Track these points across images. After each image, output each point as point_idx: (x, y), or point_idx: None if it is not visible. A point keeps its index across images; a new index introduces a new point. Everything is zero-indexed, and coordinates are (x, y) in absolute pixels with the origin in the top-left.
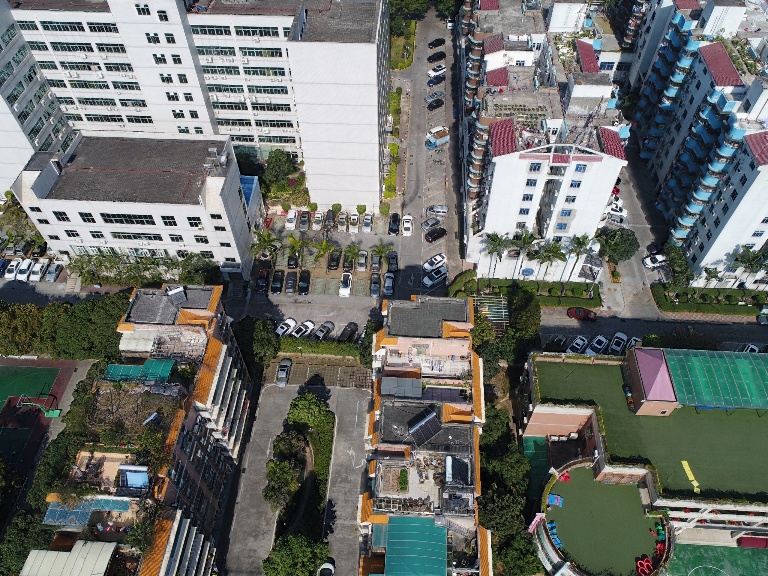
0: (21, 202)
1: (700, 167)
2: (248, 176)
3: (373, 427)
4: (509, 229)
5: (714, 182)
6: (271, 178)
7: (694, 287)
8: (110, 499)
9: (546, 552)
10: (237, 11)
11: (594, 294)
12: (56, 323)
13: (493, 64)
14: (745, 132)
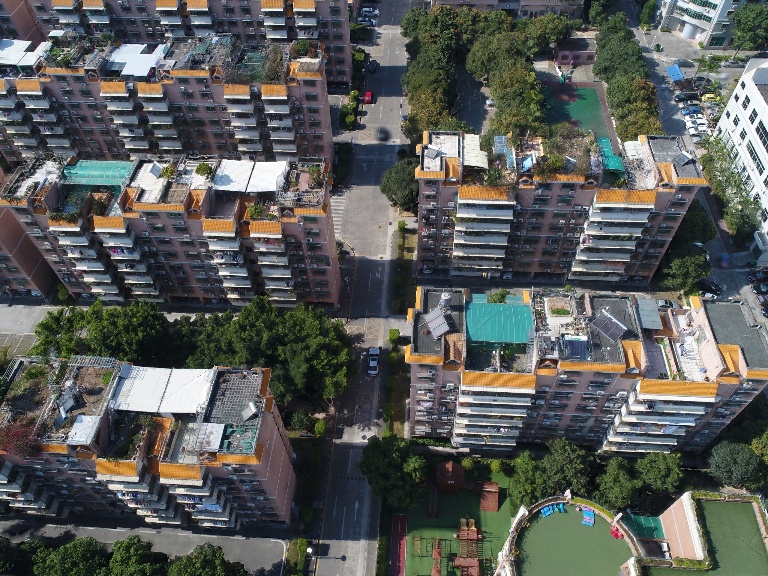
0: (744, 73)
1: None
2: None
3: None
4: None
5: None
6: None
7: None
8: None
9: None
10: None
11: None
12: None
13: None
14: None
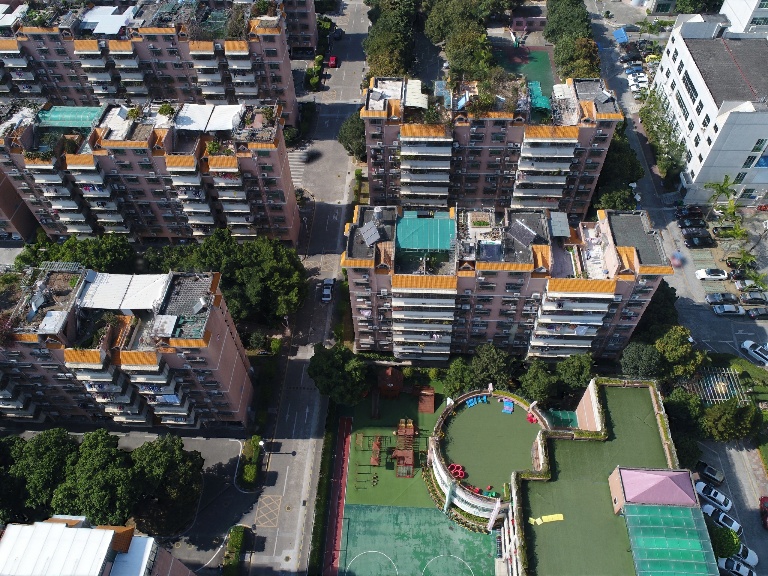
0: (674, 29)
1: None
2: None
3: None
4: None
5: None
6: None
7: None
8: None
9: None
10: None
11: None
12: None
13: None
14: None
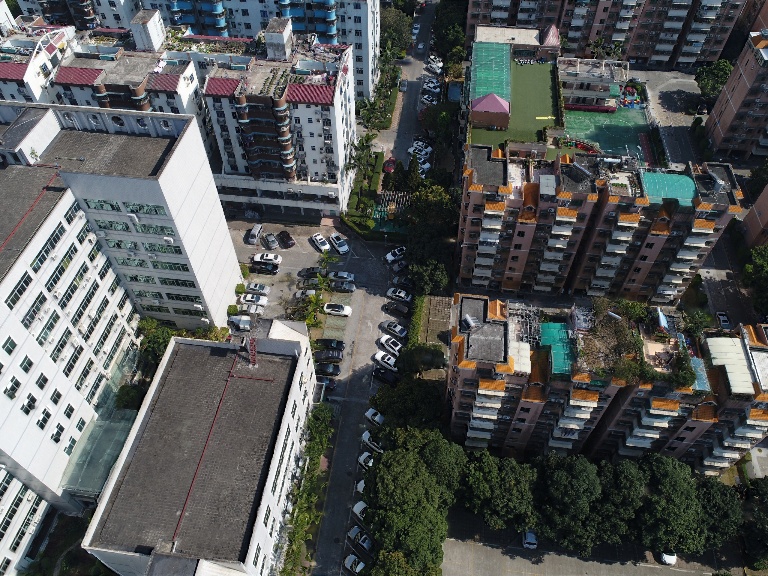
0: None
1: None
2: None
3: (572, 210)
4: (343, 156)
5: (336, 41)
6: None
7: None
8: None
9: None
10: (2, 255)
11: (373, 154)
12: None
13: (183, 93)
14: None
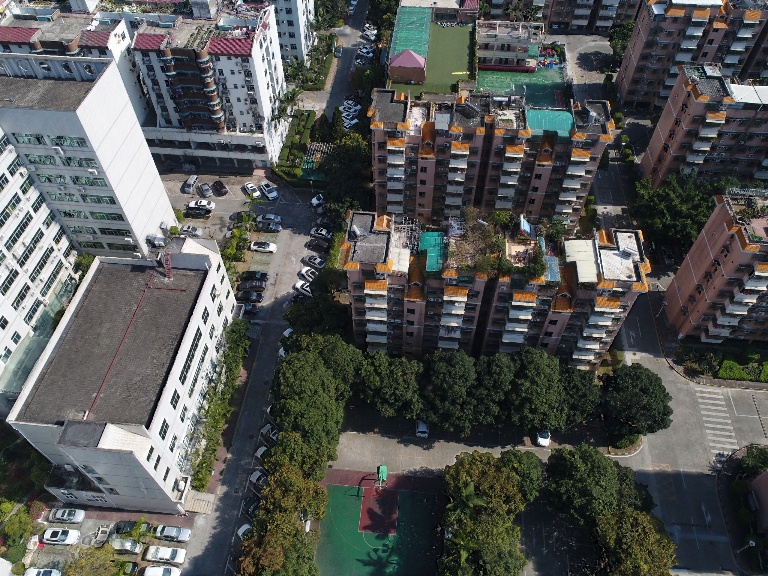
0: (140, 462)
1: None
2: None
3: (465, 144)
4: (269, 108)
5: None
6: None
7: None
8: None
9: None
10: None
11: (306, 112)
12: None
13: (114, 49)
14: None
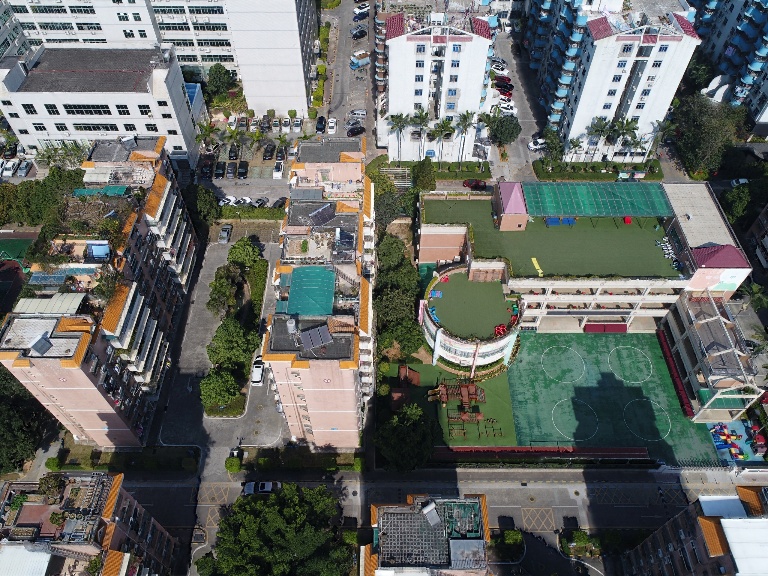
0: None
1: (563, 57)
2: (192, 83)
3: None
4: (409, 111)
5: (572, 66)
6: (213, 88)
7: (567, 162)
8: (80, 268)
9: (429, 330)
10: None
11: (485, 169)
12: (29, 194)
13: None
14: (587, 18)
